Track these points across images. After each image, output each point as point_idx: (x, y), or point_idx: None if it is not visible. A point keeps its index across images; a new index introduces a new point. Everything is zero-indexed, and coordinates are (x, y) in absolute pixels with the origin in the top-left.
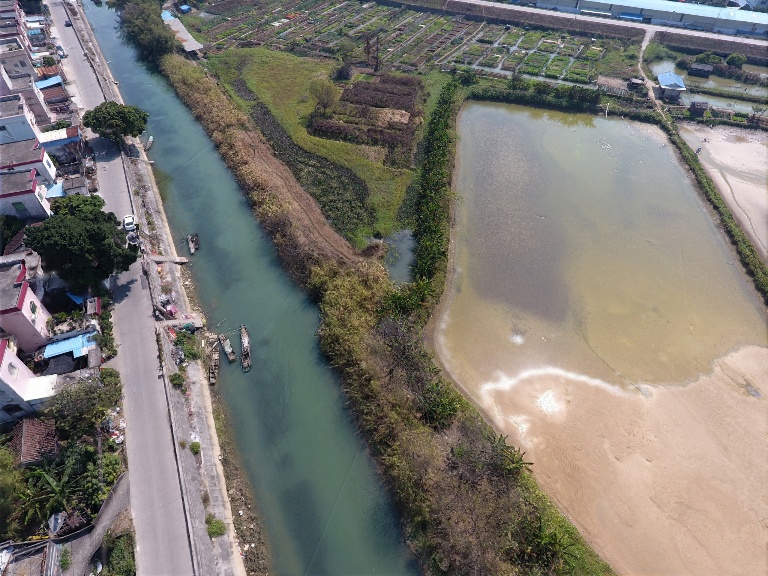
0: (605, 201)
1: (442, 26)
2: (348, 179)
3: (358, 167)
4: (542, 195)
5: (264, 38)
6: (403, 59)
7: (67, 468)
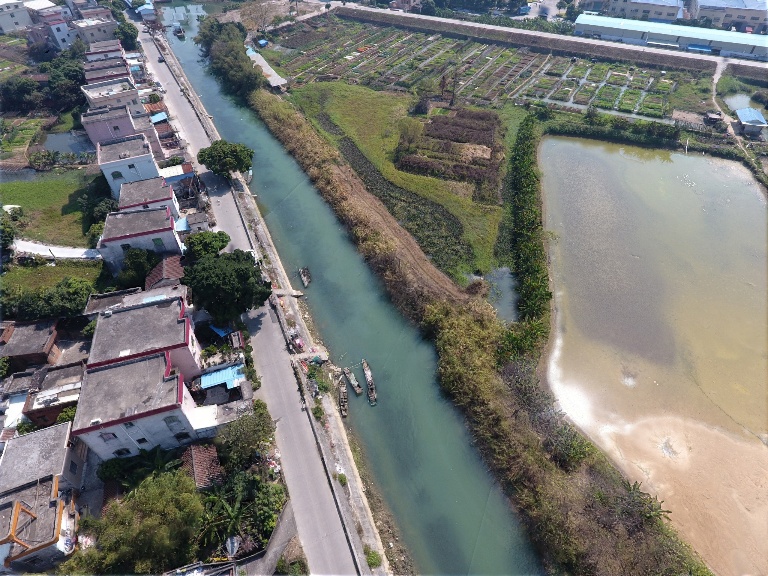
0: (697, 241)
1: (508, 58)
2: (441, 215)
3: (449, 203)
4: (633, 234)
5: (340, 72)
6: (476, 93)
7: (239, 495)
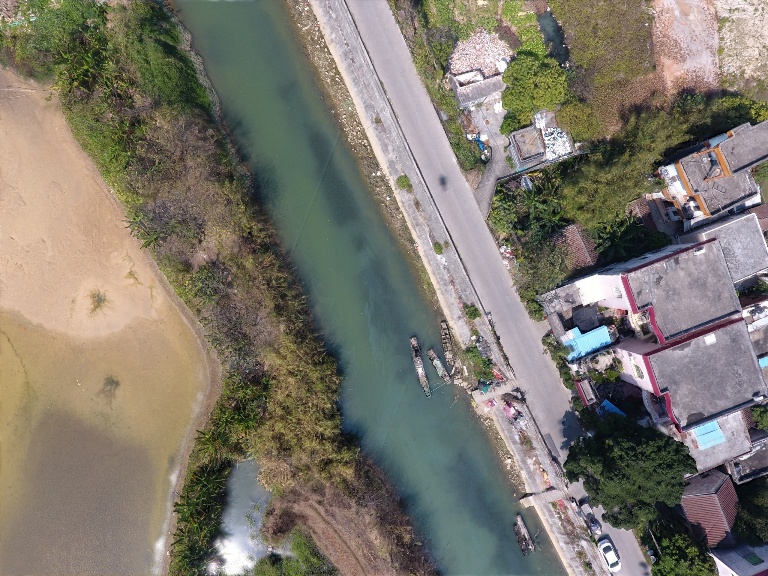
0: None
1: None
2: None
3: None
4: None
5: None
6: None
7: None
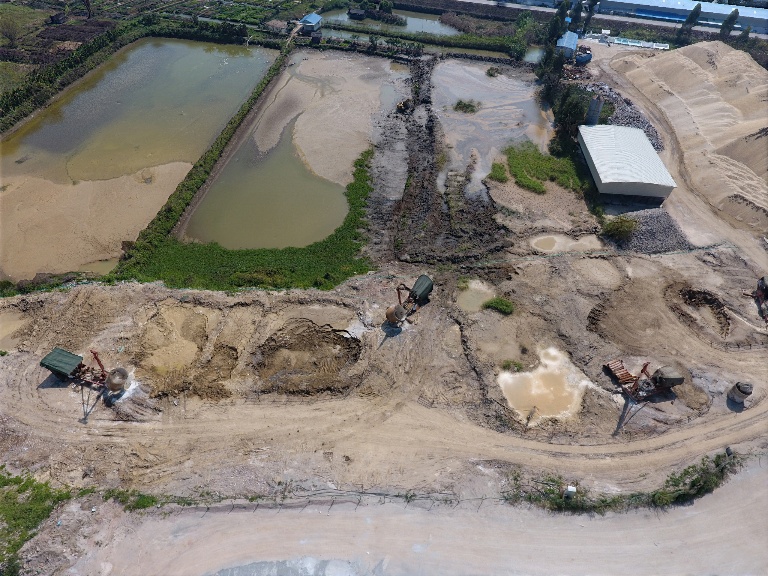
0: (179, 94)
1: None
2: None
3: (4, 76)
4: (134, 91)
5: None
6: (122, 10)
7: None
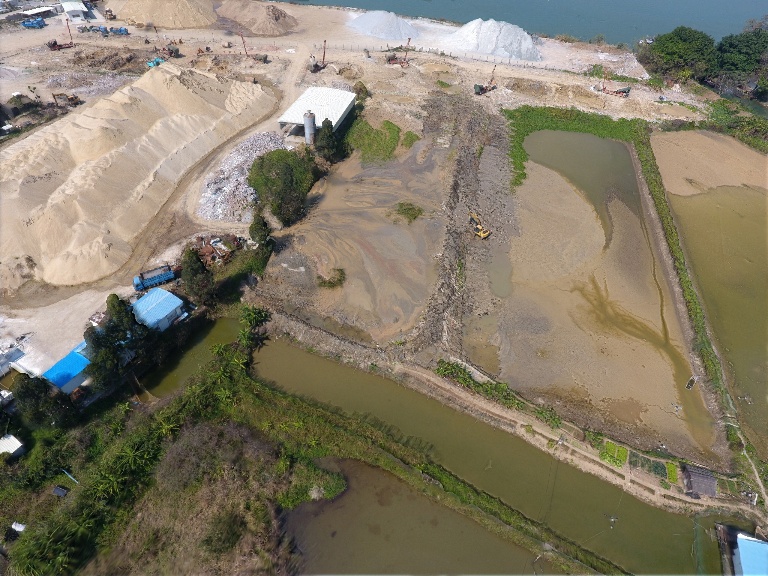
0: None
1: None
2: None
3: None
4: None
5: None
6: None
7: None
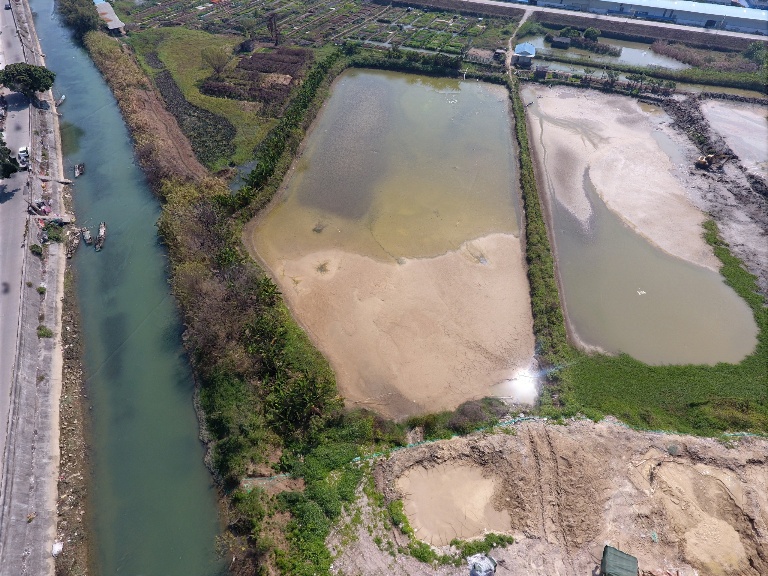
0: (433, 140)
1: (351, 9)
2: (222, 126)
3: (233, 117)
4: (382, 137)
5: (185, 19)
6: (304, 35)
7: None
